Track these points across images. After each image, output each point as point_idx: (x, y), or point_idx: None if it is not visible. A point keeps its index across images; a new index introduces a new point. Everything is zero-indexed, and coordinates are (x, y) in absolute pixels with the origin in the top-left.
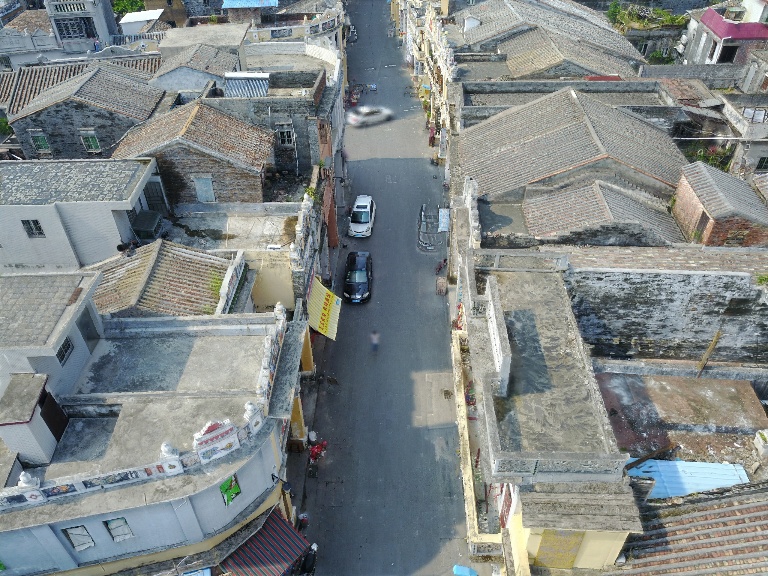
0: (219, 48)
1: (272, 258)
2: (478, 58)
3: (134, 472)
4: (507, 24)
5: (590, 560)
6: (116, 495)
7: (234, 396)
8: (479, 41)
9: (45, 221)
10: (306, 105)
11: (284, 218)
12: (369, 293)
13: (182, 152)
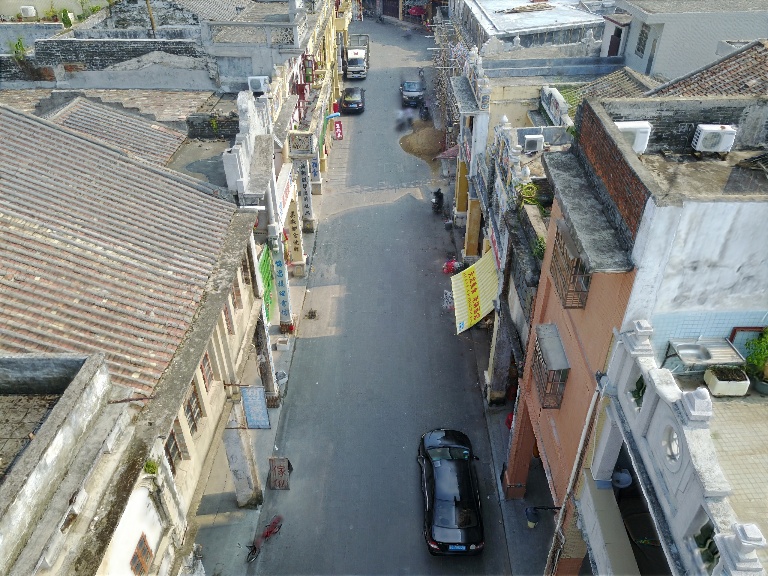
0: None
1: None
2: None
3: None
4: None
5: None
6: None
7: None
8: None
9: None
10: None
11: None
12: None
13: None
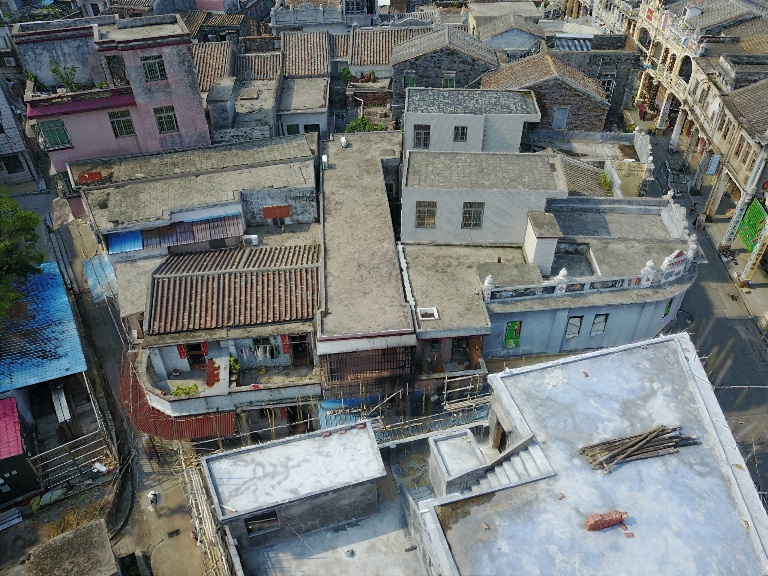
0: (525, 18)
1: (630, 168)
2: (713, 40)
3: (622, 281)
4: (732, 13)
5: None
6: (610, 295)
7: (669, 243)
8: (706, 27)
9: (472, 128)
10: (632, 59)
11: (616, 145)
12: None
13: (555, 86)
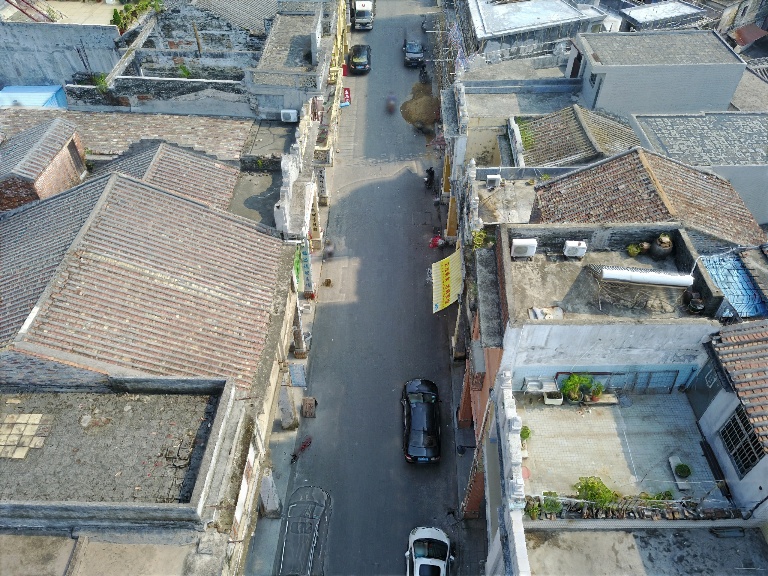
0: None
1: None
2: None
3: None
4: None
5: None
6: None
7: None
8: None
9: None
10: None
11: None
12: None
13: None
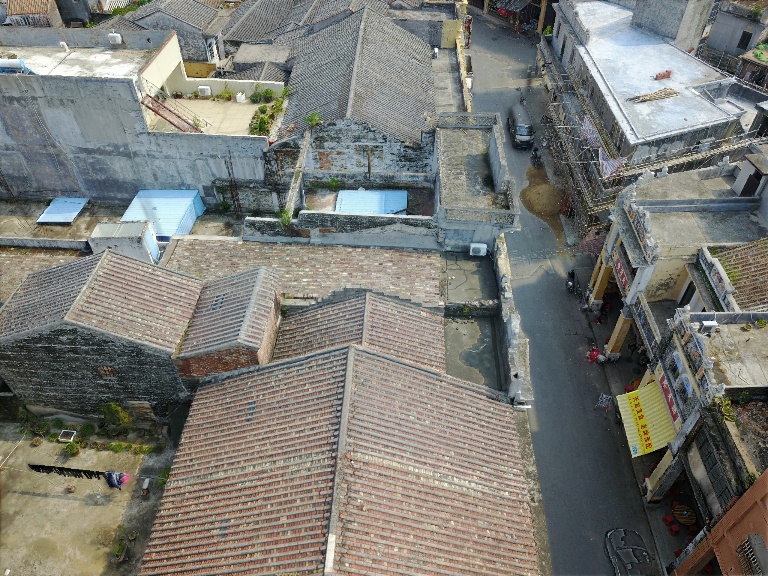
0: None
1: None
2: None
3: None
4: None
5: None
6: None
7: None
8: None
9: None
10: None
11: None
12: None
13: None
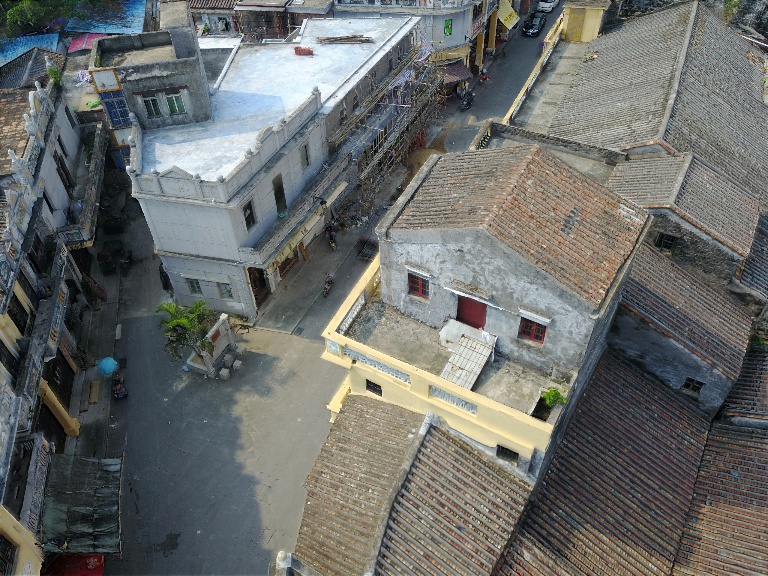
0: None
1: None
2: None
3: (415, 2)
4: None
5: (587, 35)
6: (406, 9)
7: None
8: None
9: None
10: None
11: None
12: (538, 31)
13: None
